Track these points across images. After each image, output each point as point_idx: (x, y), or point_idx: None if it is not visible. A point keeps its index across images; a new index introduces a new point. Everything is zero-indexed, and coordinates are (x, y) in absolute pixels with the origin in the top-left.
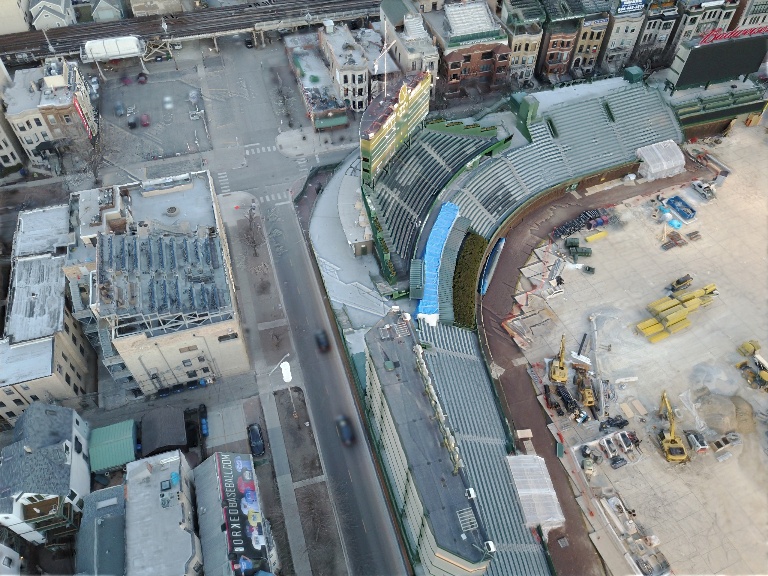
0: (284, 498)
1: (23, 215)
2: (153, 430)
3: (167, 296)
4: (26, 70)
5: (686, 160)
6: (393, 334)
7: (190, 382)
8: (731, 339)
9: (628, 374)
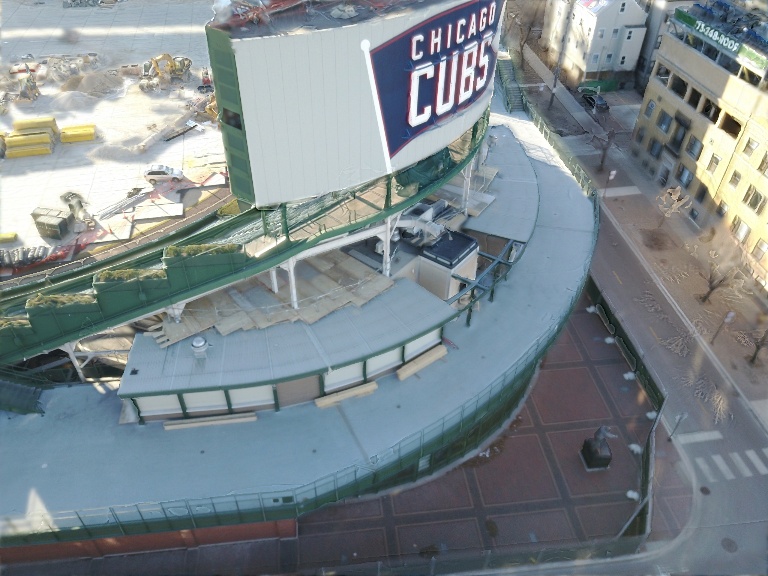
0: None
1: None
2: None
3: None
4: None
5: None
6: None
7: None
8: None
9: (156, 112)
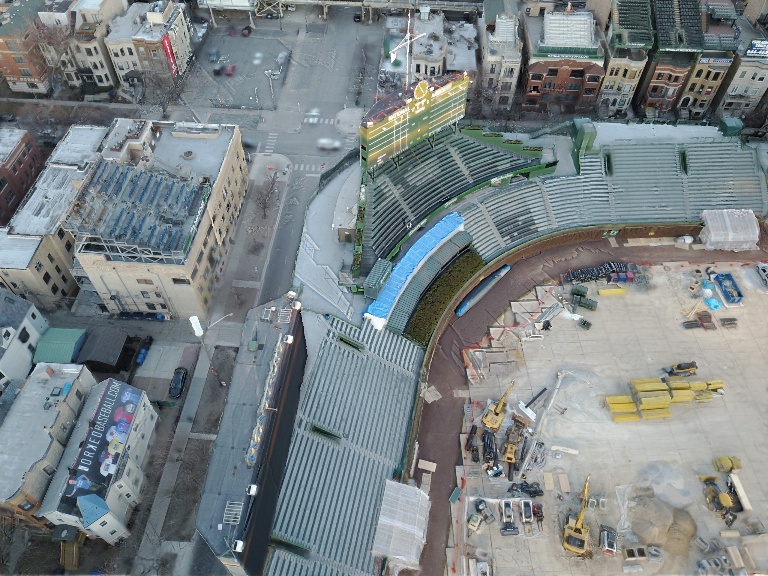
0: (175, 443)
1: (74, 128)
2: (93, 344)
3: (130, 227)
4: (139, 3)
5: (763, 237)
6: (275, 318)
7: (149, 313)
8: (712, 447)
9: (570, 445)
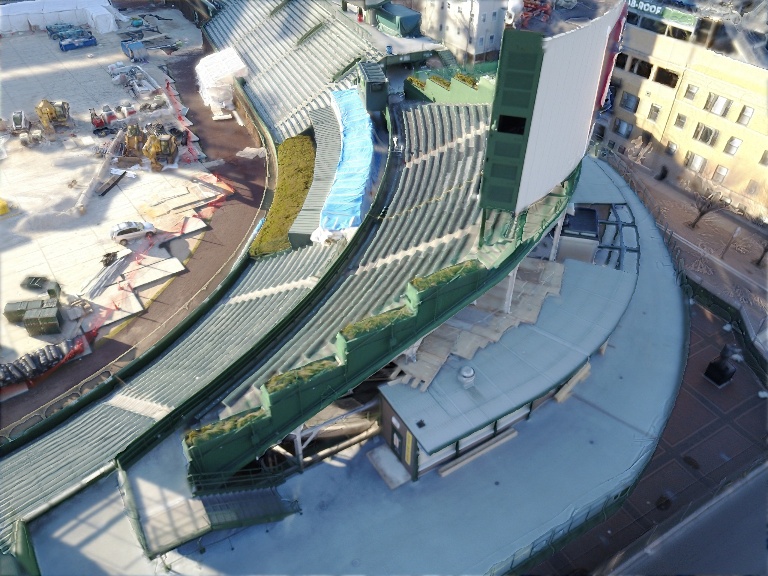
0: None
1: None
2: None
3: None
4: None
5: None
6: None
7: None
8: None
9: (63, 167)
